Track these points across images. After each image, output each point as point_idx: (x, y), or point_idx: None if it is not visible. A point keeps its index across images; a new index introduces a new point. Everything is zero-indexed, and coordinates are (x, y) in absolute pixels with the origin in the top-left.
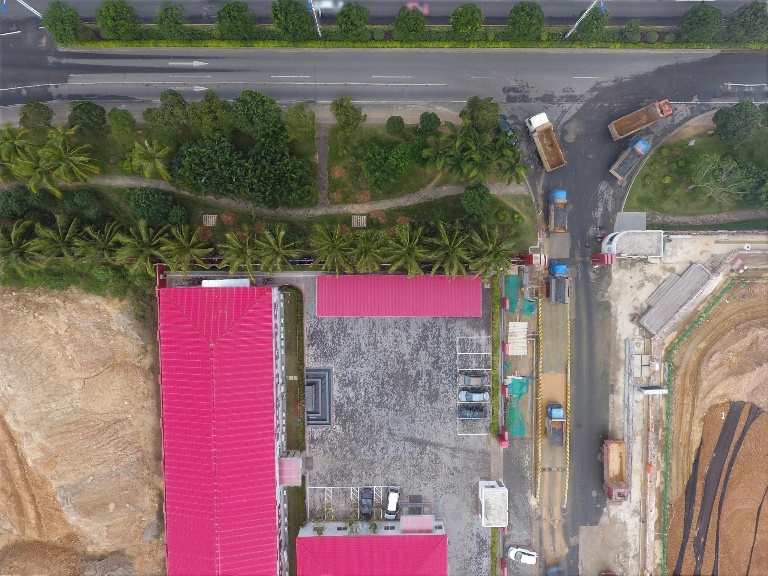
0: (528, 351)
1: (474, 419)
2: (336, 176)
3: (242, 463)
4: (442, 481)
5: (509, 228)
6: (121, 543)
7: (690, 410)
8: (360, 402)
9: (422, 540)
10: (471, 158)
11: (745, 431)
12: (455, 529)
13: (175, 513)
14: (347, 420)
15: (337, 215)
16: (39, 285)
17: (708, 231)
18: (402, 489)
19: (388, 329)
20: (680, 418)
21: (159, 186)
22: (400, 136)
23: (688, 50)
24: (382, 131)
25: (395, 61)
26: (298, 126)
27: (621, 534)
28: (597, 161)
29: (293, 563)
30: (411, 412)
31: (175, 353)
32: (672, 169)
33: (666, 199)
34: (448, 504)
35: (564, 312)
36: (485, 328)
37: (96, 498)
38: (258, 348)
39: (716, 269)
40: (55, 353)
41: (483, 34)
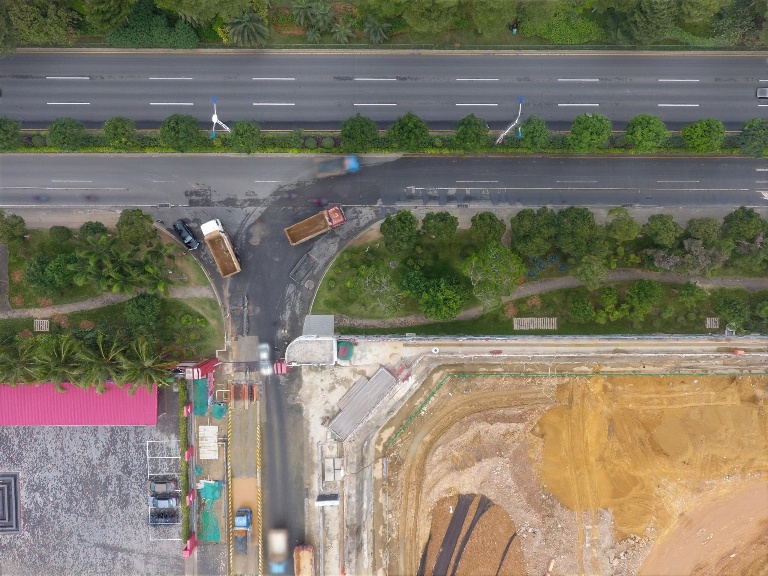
0: (220, 455)
1: (166, 524)
2: (16, 280)
3: None
4: None
5: (194, 332)
6: None
7: (414, 505)
8: (48, 508)
9: None
10: (110, 275)
11: (473, 525)
12: None
13: None
14: (36, 526)
15: (19, 319)
16: None
17: (383, 338)
18: None
19: (75, 433)
20: (405, 513)
21: None
22: (81, 240)
23: (370, 154)
24: None
25: (75, 165)
26: None
27: None
28: (283, 264)
29: None
30: (101, 518)
31: None
32: (353, 274)
33: (353, 302)
34: None
35: (254, 416)
36: (175, 432)
37: None
38: None
39: None
40: None
41: (159, 140)
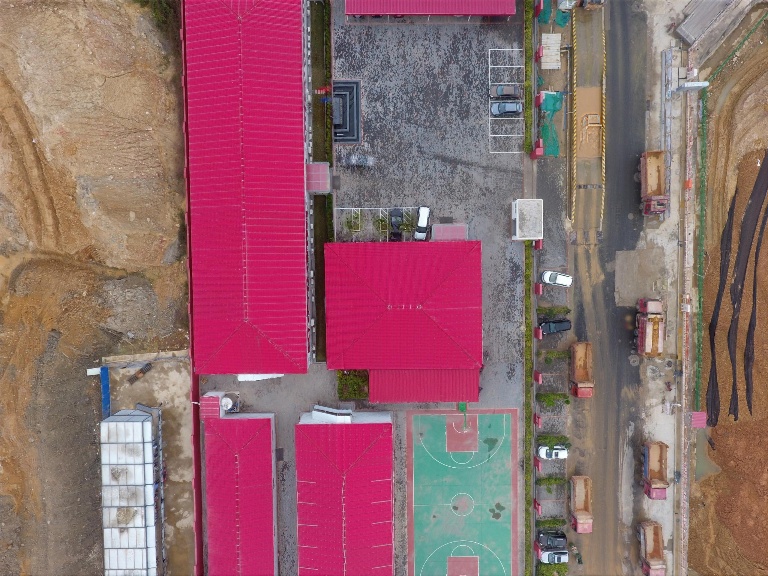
0: (562, 65)
1: (506, 136)
2: None
3: (270, 149)
4: (474, 202)
5: None
6: (141, 262)
7: (725, 154)
8: (389, 118)
9: (455, 246)
10: None
11: None
12: (487, 253)
13: (199, 206)
14: (375, 137)
15: None
16: None
17: None
18: (432, 210)
19: (418, 41)
20: (715, 163)
21: None
22: None
23: None
24: None
25: None
26: None
27: (659, 259)
28: None
29: (319, 289)
30: (441, 129)
31: (201, 34)
32: None
33: None
34: (480, 226)
35: (599, 22)
36: (517, 40)
37: (116, 200)
38: (287, 29)
39: None
40: (75, 46)
41: None
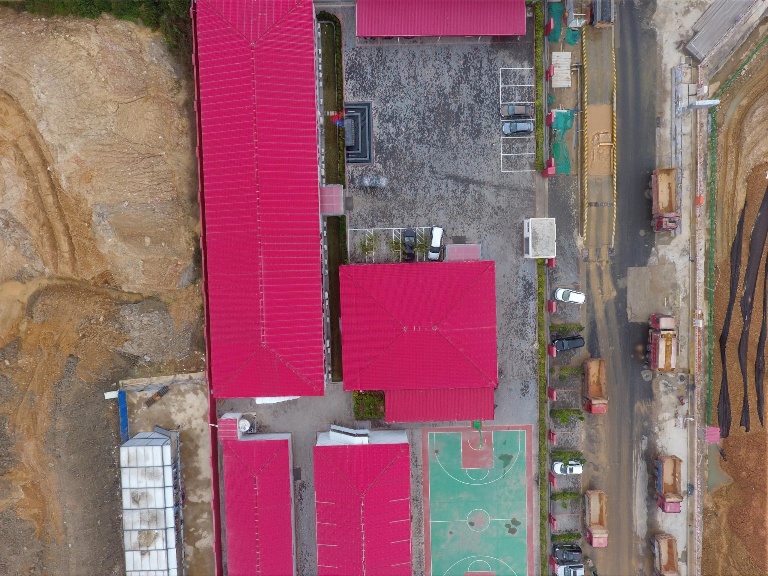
0: (572, 83)
1: (518, 155)
2: None
3: (284, 174)
4: (486, 221)
5: None
6: (157, 286)
7: (734, 167)
8: (401, 138)
9: (469, 266)
10: None
11: None
12: (500, 272)
13: (215, 232)
14: (388, 158)
15: None
16: (69, 11)
17: None
18: (445, 230)
19: (428, 61)
20: (724, 176)
21: None
22: None
23: None
24: None
25: None
26: None
27: (670, 275)
28: None
29: (334, 310)
30: (453, 148)
31: (213, 60)
32: None
33: None
34: (492, 245)
35: (608, 40)
36: (528, 59)
37: (132, 226)
38: (299, 54)
39: None
40: (88, 73)
41: None
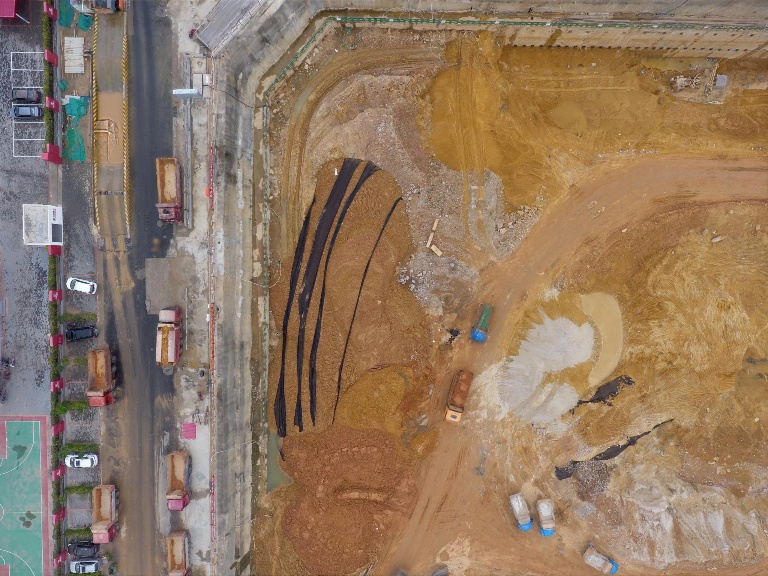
0: (87, 69)
1: (30, 140)
2: None
3: None
4: None
5: None
6: None
7: (297, 162)
8: None
9: None
10: None
11: (358, 187)
12: (13, 258)
13: None
14: None
15: None
16: None
17: None
18: None
19: None
20: (288, 171)
21: None
22: None
23: None
24: None
25: None
26: None
27: (189, 268)
28: None
29: None
30: None
31: None
32: None
33: None
34: (5, 231)
35: (121, 27)
36: (40, 43)
37: None
38: None
39: None
40: None
41: None
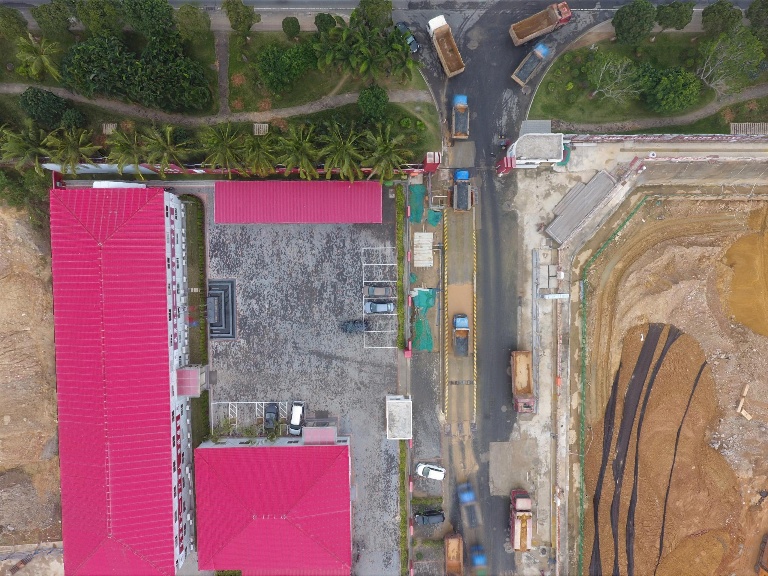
0: (434, 262)
1: (380, 332)
2: (237, 84)
3: (133, 367)
4: (349, 396)
5: None
6: (19, 459)
7: (608, 331)
8: (264, 315)
9: (323, 451)
10: (360, 51)
11: (664, 353)
12: (362, 445)
13: (66, 421)
14: (251, 333)
15: (238, 123)
16: None
17: (609, 135)
18: (308, 404)
19: (292, 240)
20: (598, 339)
21: (58, 94)
22: (301, 43)
23: None
24: (283, 38)
25: None
26: (189, 24)
27: (532, 450)
28: (501, 69)
29: None
30: (316, 325)
31: (65, 255)
32: (574, 75)
33: (570, 106)
34: (355, 420)
35: (470, 222)
36: (390, 239)
37: None
38: (150, 250)
39: (621, 177)
40: None
41: None
